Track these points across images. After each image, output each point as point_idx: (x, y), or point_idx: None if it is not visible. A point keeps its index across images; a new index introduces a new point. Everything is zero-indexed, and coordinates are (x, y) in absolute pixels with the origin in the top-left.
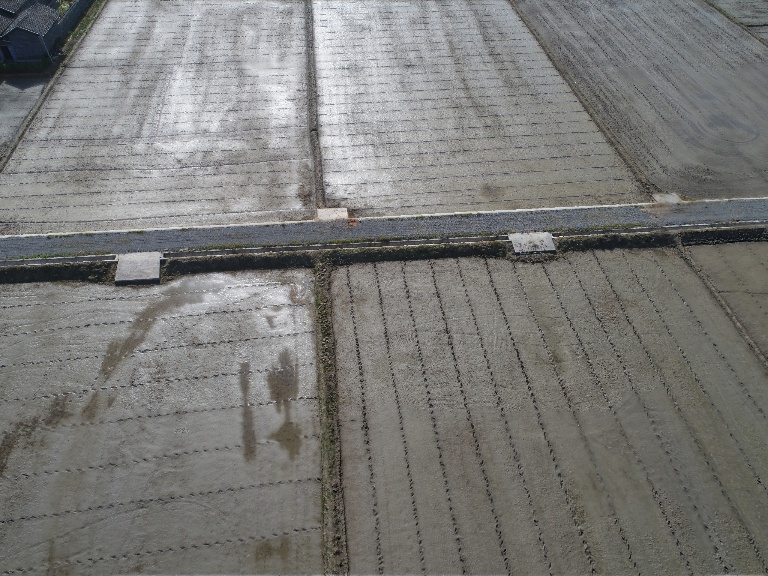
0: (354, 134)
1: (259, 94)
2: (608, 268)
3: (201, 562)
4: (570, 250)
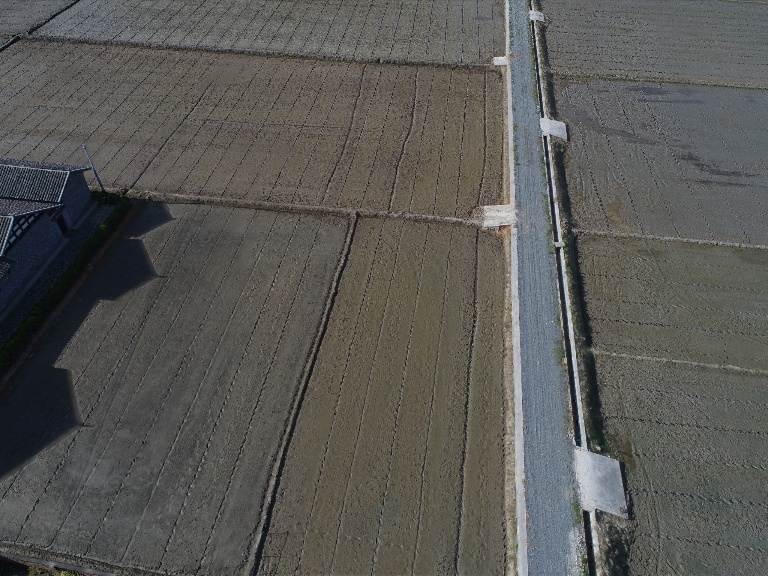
0: (392, 47)
1: (294, 78)
2: (556, 7)
3: (765, 115)
4: (541, 11)
